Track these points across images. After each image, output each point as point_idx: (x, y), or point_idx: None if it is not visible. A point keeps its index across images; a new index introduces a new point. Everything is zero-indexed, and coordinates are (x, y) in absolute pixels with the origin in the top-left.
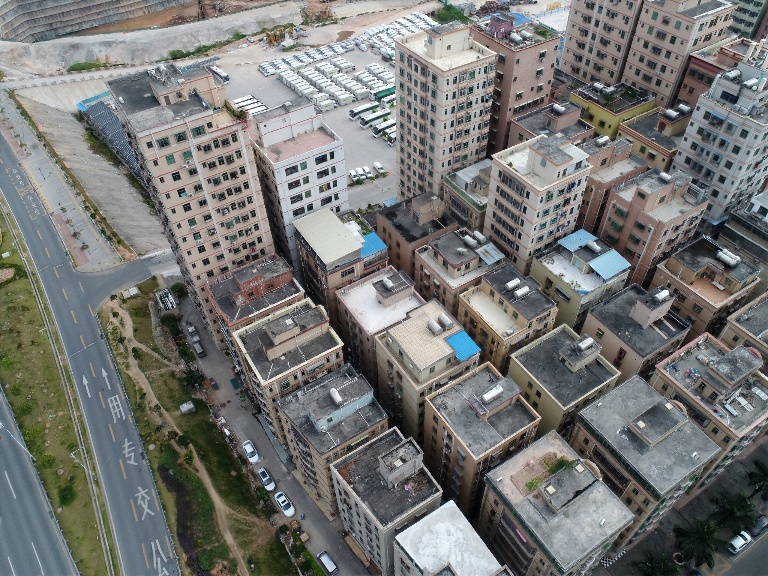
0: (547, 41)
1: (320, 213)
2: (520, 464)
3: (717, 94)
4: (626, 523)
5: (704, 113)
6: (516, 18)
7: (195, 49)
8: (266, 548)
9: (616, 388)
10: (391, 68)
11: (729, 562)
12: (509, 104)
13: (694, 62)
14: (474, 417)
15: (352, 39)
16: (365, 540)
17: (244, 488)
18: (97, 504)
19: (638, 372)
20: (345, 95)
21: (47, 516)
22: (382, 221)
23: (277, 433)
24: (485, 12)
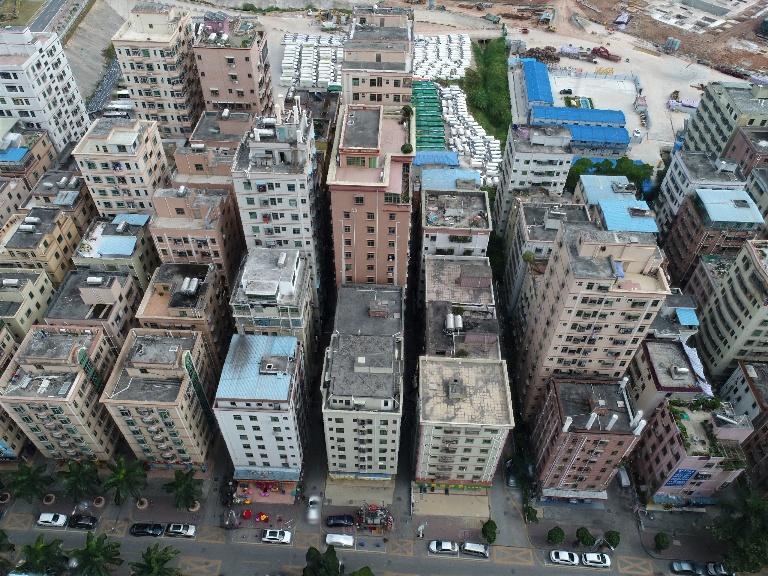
0: (231, 48)
1: (9, 120)
2: None
3: None
4: None
5: None
6: (224, 21)
7: (267, 8)
8: None
9: None
10: None
11: (30, 527)
12: (205, 96)
13: None
14: None
15: None
16: None
17: None
18: None
19: None
20: (307, 78)
21: None
22: (66, 149)
23: None
24: (529, 54)
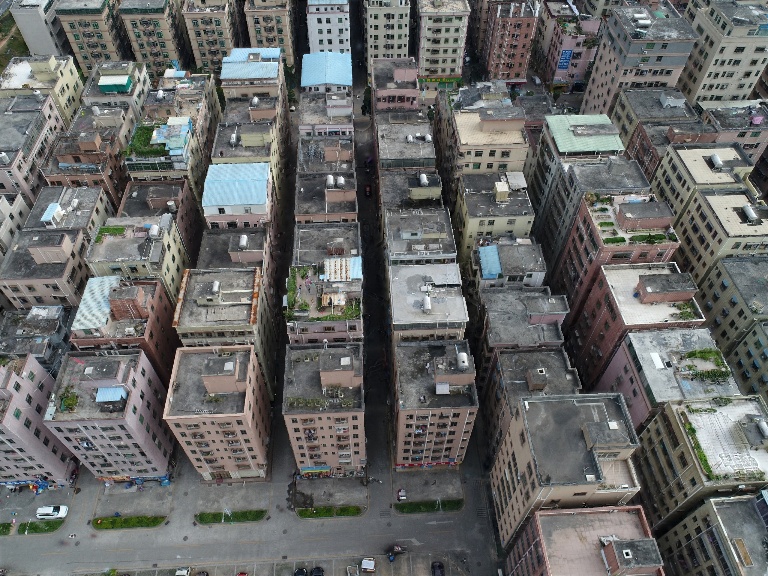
0: None
1: None
2: None
3: None
4: (94, 9)
5: None
6: None
7: None
8: None
9: None
10: None
11: None
12: None
13: None
14: None
15: None
16: None
17: None
18: None
19: None
20: None
21: None
22: None
23: None
24: None
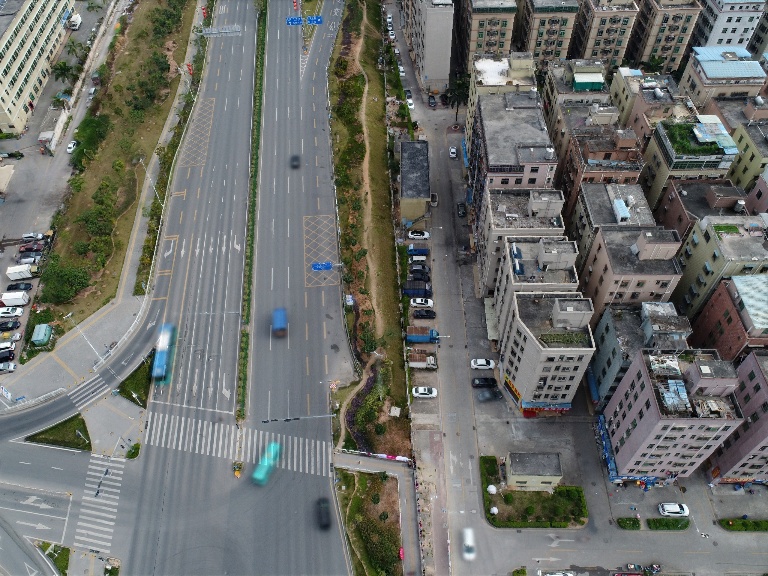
0: None
1: None
2: None
3: None
4: (511, 7)
5: None
6: None
7: None
8: (375, 39)
9: None
10: None
11: None
12: None
13: None
14: None
15: None
16: None
17: (378, 24)
18: (318, 6)
19: (581, 2)
20: None
21: (298, 4)
22: None
23: (403, 3)
24: None
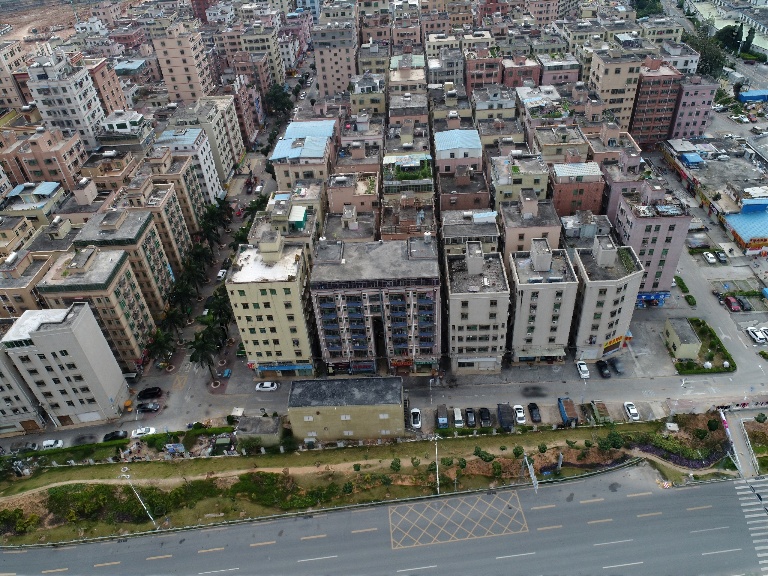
0: None
1: None
2: (53, 273)
3: (35, 78)
4: (123, 255)
5: (37, 91)
6: None
7: None
8: None
9: (86, 223)
10: None
11: None
12: None
13: (18, 77)
14: (12, 280)
15: None
16: (3, 404)
17: None
18: None
19: None
20: None
21: None
22: None
23: None
24: None
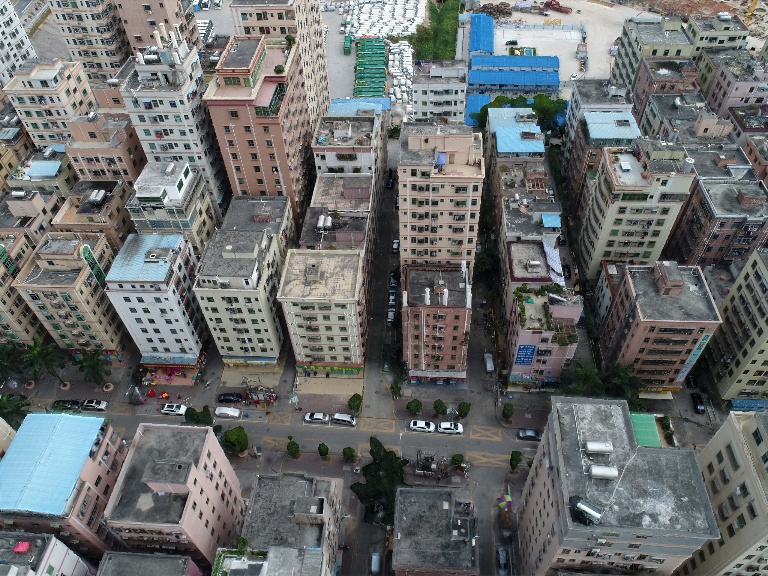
0: None
1: None
2: None
3: None
4: None
5: None
6: None
7: None
8: None
9: None
10: (337, 33)
11: None
12: (131, 43)
13: None
14: None
15: (343, 2)
16: None
17: None
18: None
19: None
20: None
21: None
22: None
23: None
24: (482, 10)
